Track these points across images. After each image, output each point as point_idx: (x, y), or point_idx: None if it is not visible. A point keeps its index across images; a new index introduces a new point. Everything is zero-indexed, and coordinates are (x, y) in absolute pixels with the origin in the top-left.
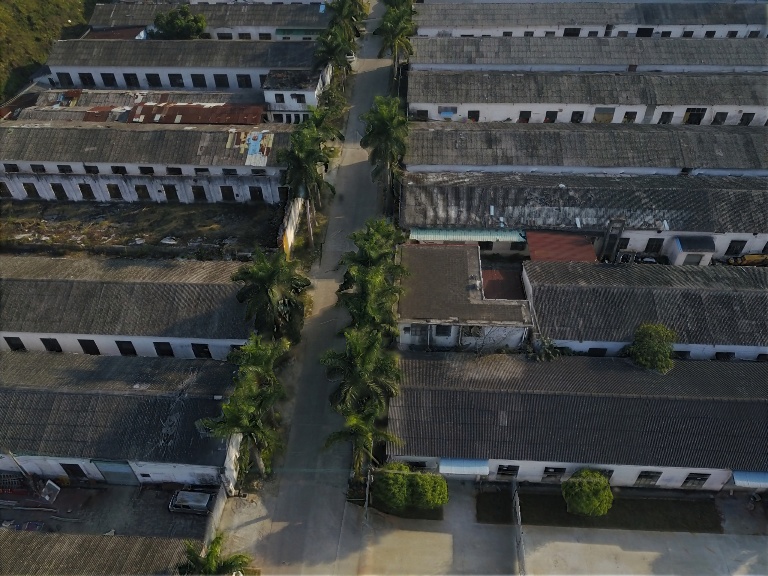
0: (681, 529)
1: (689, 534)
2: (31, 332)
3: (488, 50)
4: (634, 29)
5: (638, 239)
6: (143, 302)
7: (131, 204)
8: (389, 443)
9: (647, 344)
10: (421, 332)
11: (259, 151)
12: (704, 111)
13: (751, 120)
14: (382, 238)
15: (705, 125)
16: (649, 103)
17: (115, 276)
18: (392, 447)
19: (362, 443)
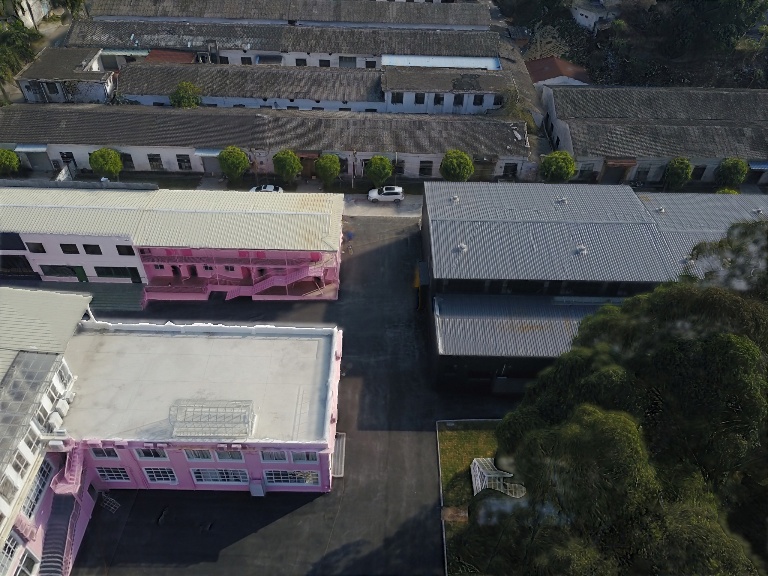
0: (171, 189)
1: None
2: None
3: None
4: None
5: (234, 58)
6: None
7: None
8: None
9: None
10: (39, 90)
11: None
12: None
13: None
14: (15, 30)
15: None
16: None
17: None
18: None
19: None
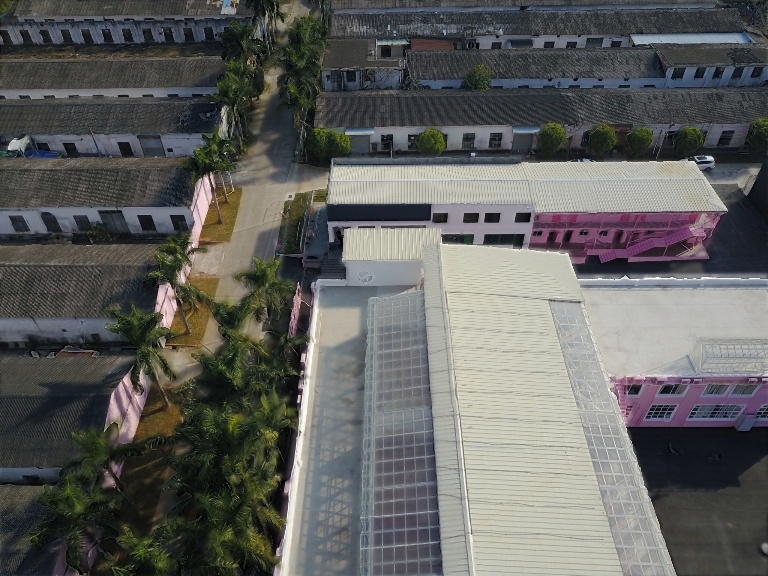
0: None
1: None
2: (88, 88)
3: None
4: None
5: (485, 44)
6: (160, 70)
7: (140, 45)
8: (316, 122)
9: (473, 76)
10: (337, 79)
11: (230, 5)
12: None
13: None
14: None
15: None
16: None
17: (140, 59)
18: (317, 124)
19: (298, 109)
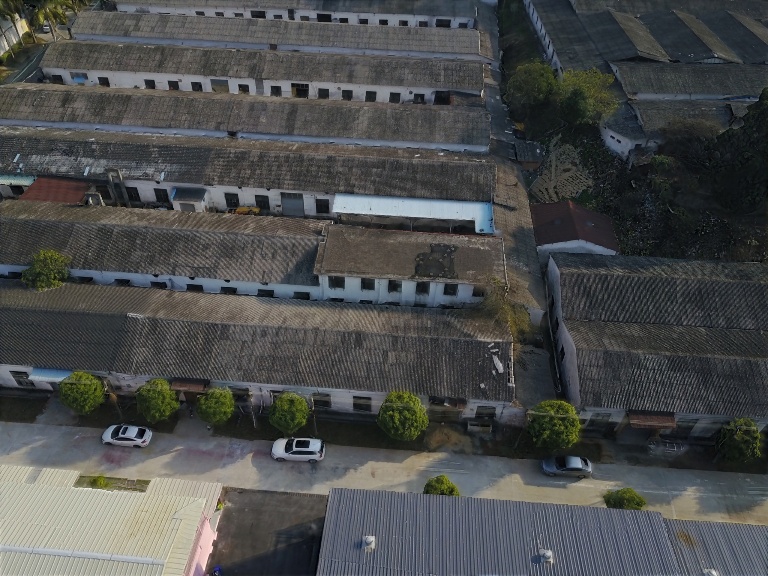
0: None
1: (3, 423)
2: None
3: (146, 25)
4: (314, 14)
5: (144, 189)
6: None
7: None
8: None
9: None
10: None
11: None
12: (307, 87)
13: (351, 97)
14: None
15: (281, 97)
16: (255, 77)
17: None
18: None
19: None
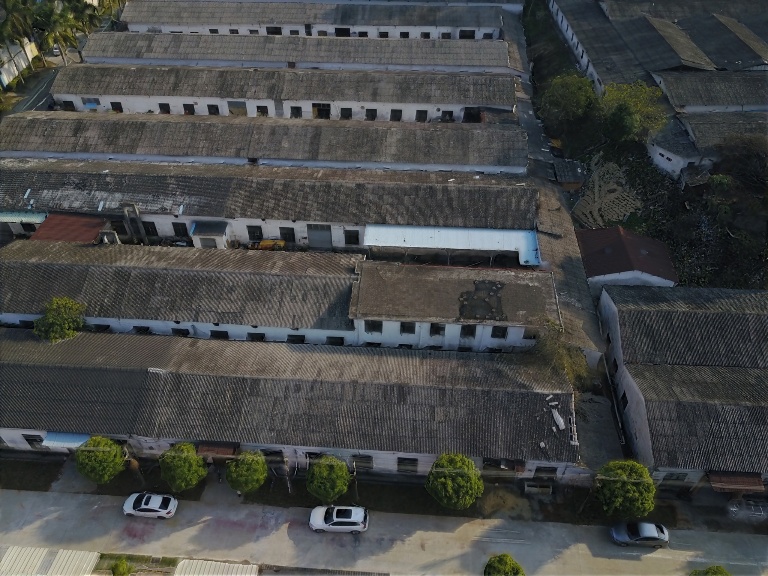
0: (12, 487)
1: (15, 491)
2: None
3: (159, 45)
4: (332, 29)
5: (162, 223)
6: None
7: None
8: None
9: None
10: None
11: None
12: (329, 106)
13: (375, 116)
14: None
15: (302, 119)
16: (274, 98)
17: None
18: None
19: None
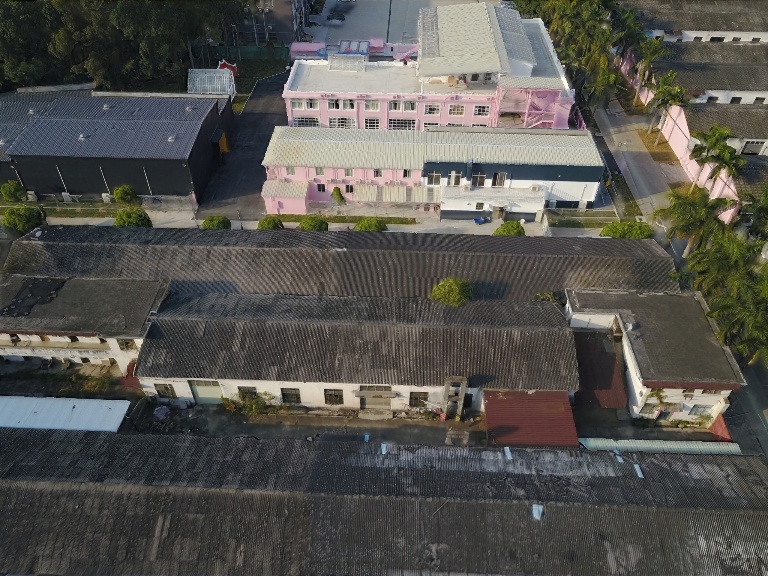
0: None
1: None
2: None
3: None
4: None
5: None
6: None
7: None
8: None
9: None
10: None
11: None
12: None
13: None
14: (763, 316)
15: None
16: None
17: None
18: None
19: None
